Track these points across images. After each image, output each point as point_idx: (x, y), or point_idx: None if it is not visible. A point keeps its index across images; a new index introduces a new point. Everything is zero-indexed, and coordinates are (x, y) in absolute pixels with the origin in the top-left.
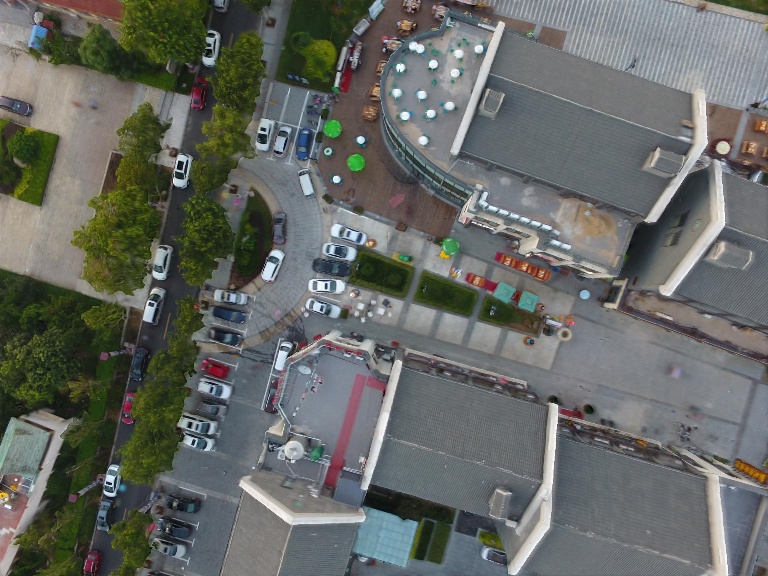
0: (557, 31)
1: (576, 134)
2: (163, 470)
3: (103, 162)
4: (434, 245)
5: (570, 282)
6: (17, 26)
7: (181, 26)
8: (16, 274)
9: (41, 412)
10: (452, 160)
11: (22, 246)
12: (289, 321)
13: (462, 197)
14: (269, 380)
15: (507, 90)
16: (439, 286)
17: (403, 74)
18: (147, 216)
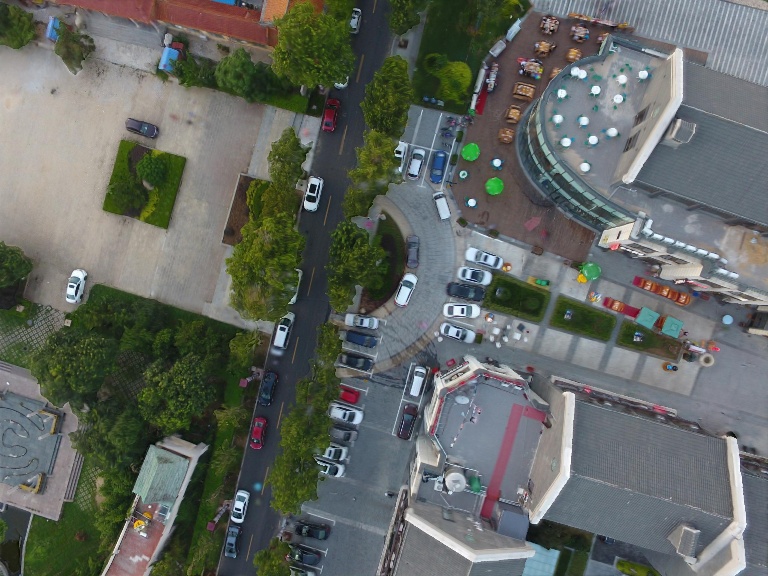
0: (698, 52)
1: (764, 164)
2: (308, 499)
3: (230, 184)
4: (571, 269)
5: (711, 307)
6: (143, 47)
7: (332, 51)
8: (142, 297)
9: (173, 438)
10: (613, 187)
11: (147, 269)
12: (421, 346)
13: (611, 222)
14: (400, 405)
15: (696, 120)
16: (577, 311)
17: (563, 100)
18: (299, 243)
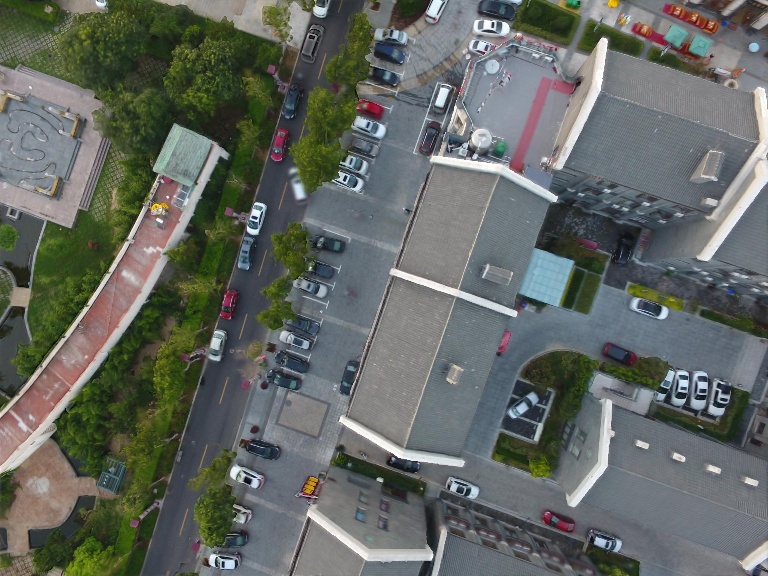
0: None
1: None
2: (329, 178)
3: None
4: None
5: (738, 37)
6: None
7: None
8: None
9: None
10: None
11: None
12: (448, 65)
13: None
14: (423, 124)
15: None
16: None
17: None
18: None
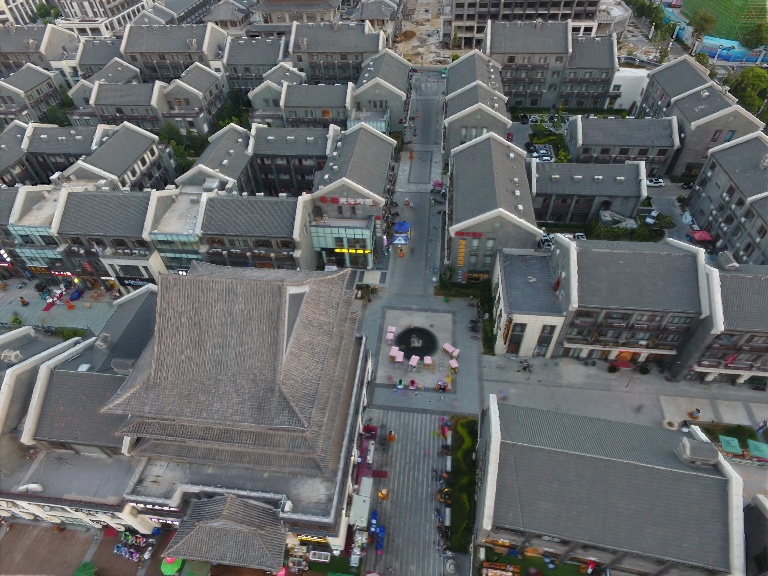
0: None
1: None
2: None
3: None
4: None
5: None
6: None
7: None
8: None
9: None
10: None
11: None
12: None
13: None
14: None
15: None
16: None
17: None
18: None
